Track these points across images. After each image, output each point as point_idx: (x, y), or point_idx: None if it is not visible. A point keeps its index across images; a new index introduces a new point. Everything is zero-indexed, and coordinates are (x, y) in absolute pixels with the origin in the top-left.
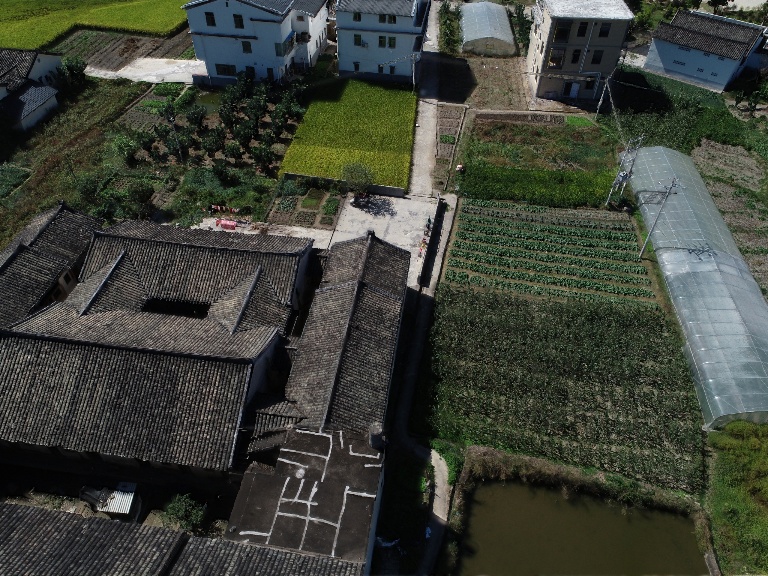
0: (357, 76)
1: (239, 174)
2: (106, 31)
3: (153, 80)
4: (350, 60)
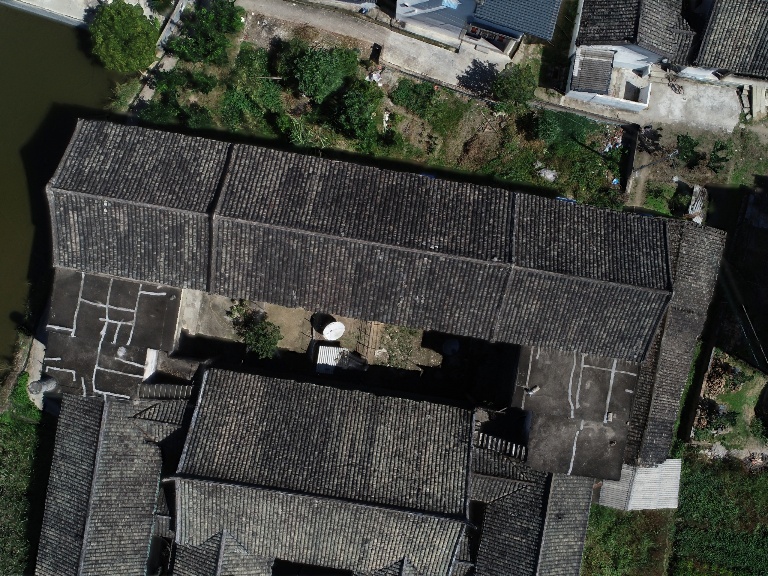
0: None
1: None
2: None
3: None
4: None
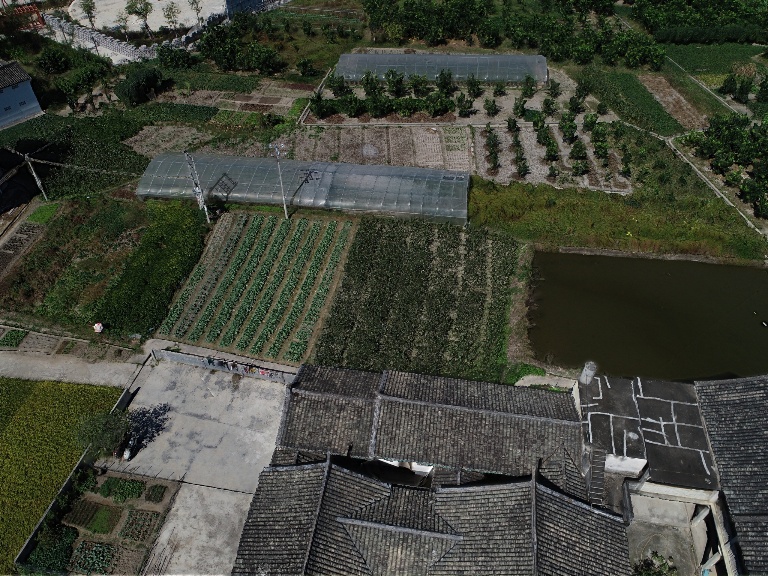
0: None
1: None
2: None
3: None
4: None
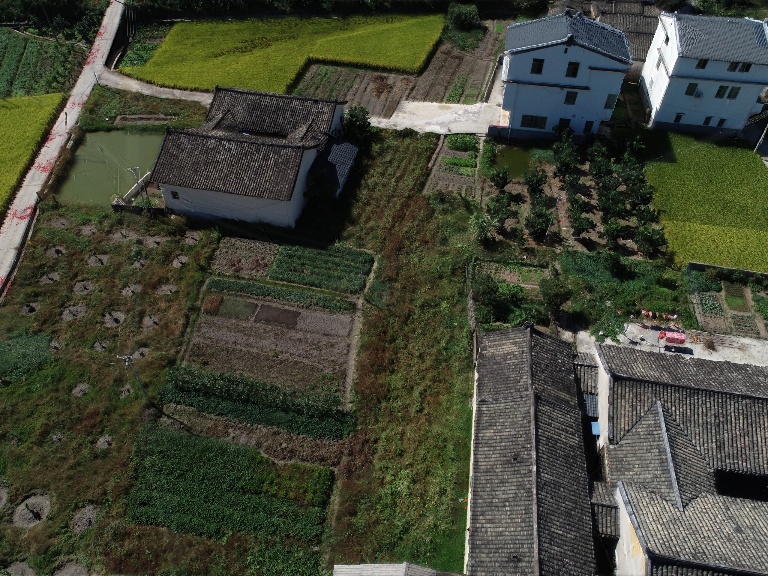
0: (674, 128)
1: (625, 261)
2: (343, 66)
3: (438, 130)
4: (673, 111)
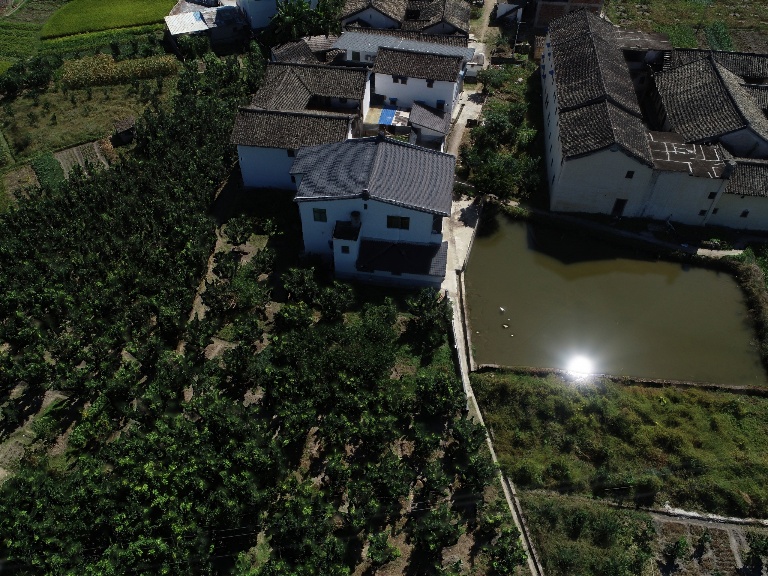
0: None
1: None
2: None
3: None
4: None
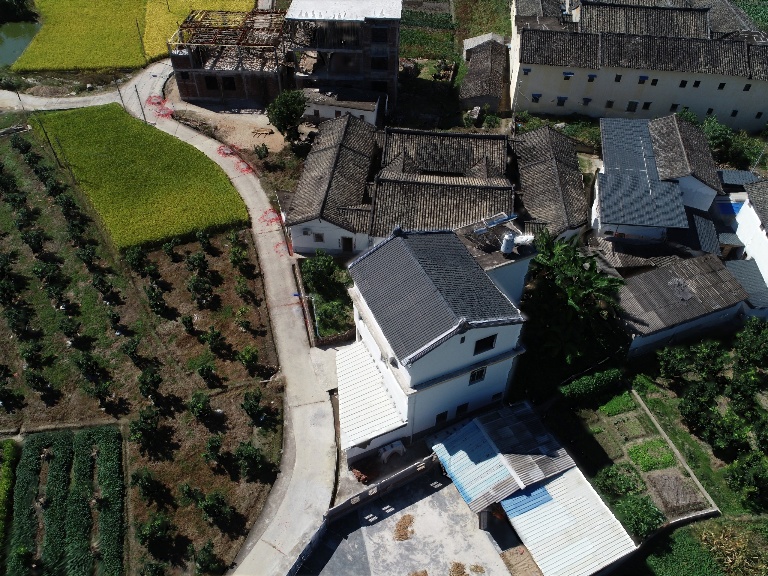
0: None
1: None
2: None
3: None
4: None
